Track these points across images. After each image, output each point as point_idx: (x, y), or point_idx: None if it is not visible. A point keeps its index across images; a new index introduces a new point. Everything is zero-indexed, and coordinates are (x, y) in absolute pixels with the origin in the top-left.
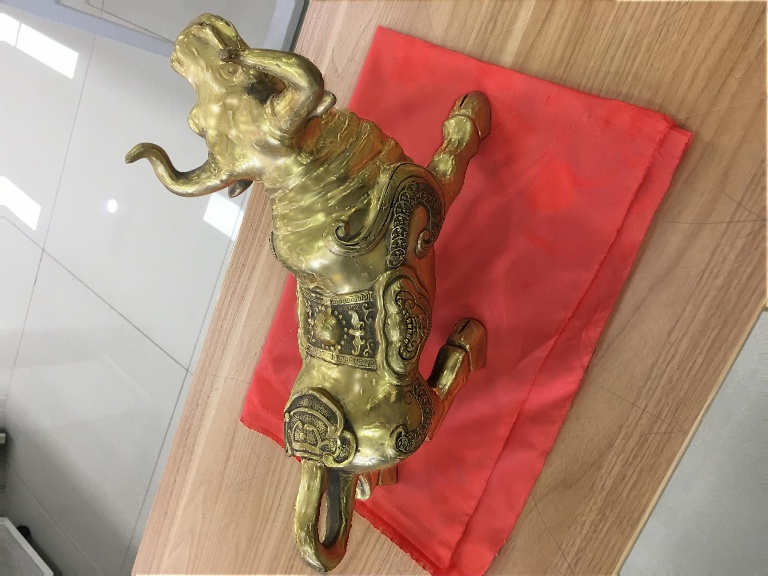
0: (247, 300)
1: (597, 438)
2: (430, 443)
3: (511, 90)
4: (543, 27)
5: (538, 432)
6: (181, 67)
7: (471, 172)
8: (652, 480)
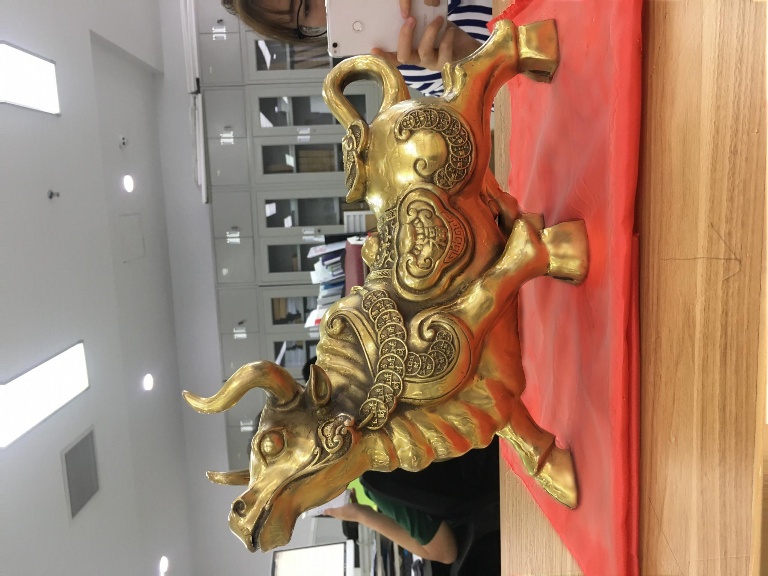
0: (708, 79)
1: None
2: (540, 116)
3: (549, 501)
4: (561, 562)
5: None
6: None
7: (564, 418)
8: None
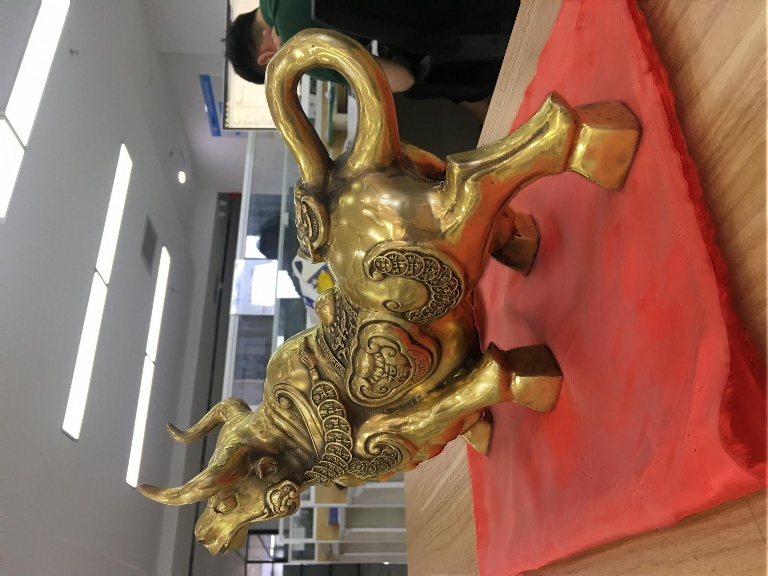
0: None
1: (515, 98)
2: None
3: None
4: None
5: (526, 120)
6: (203, 529)
7: None
8: (510, 49)
